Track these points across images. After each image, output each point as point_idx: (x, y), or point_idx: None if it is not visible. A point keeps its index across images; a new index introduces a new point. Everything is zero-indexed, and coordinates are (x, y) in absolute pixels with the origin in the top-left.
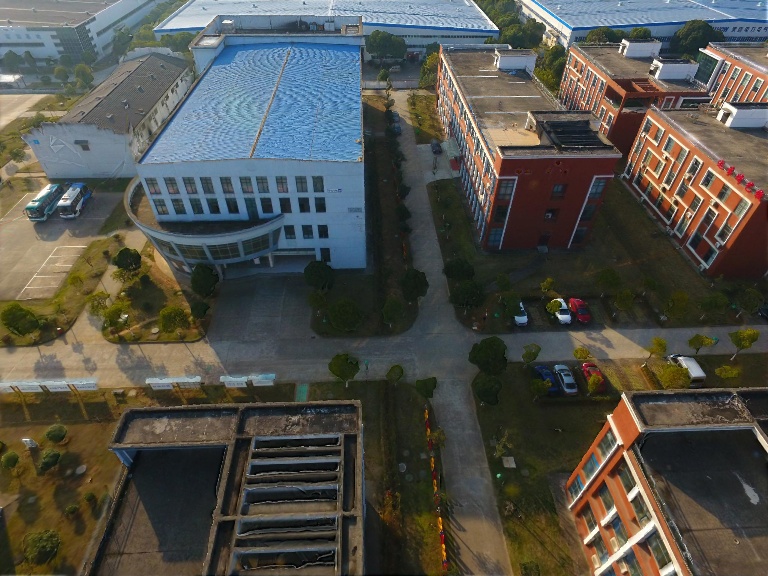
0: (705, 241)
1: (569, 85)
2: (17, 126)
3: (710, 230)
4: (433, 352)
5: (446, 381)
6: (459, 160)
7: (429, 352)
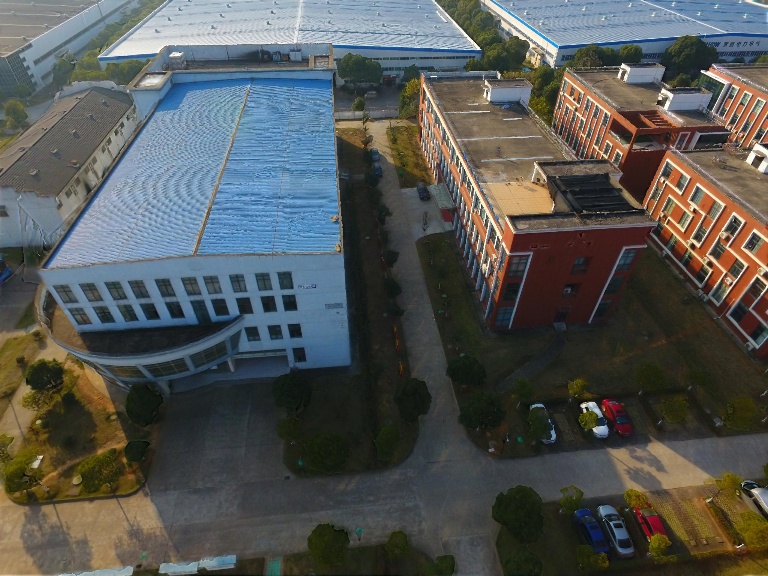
0: (753, 315)
1: (565, 114)
2: None
3: (759, 303)
4: (442, 492)
5: (463, 539)
6: (452, 211)
7: (437, 492)
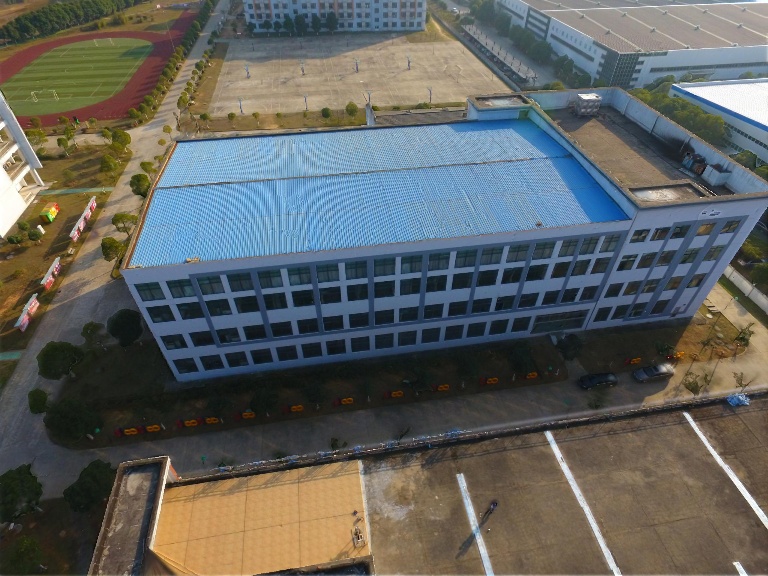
0: None
1: None
2: (447, 106)
3: None
4: None
5: None
6: None
7: (1, 465)
